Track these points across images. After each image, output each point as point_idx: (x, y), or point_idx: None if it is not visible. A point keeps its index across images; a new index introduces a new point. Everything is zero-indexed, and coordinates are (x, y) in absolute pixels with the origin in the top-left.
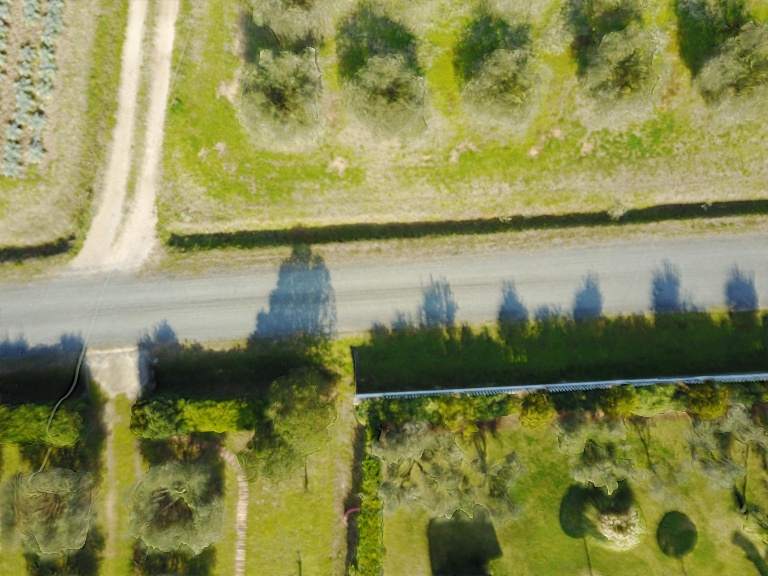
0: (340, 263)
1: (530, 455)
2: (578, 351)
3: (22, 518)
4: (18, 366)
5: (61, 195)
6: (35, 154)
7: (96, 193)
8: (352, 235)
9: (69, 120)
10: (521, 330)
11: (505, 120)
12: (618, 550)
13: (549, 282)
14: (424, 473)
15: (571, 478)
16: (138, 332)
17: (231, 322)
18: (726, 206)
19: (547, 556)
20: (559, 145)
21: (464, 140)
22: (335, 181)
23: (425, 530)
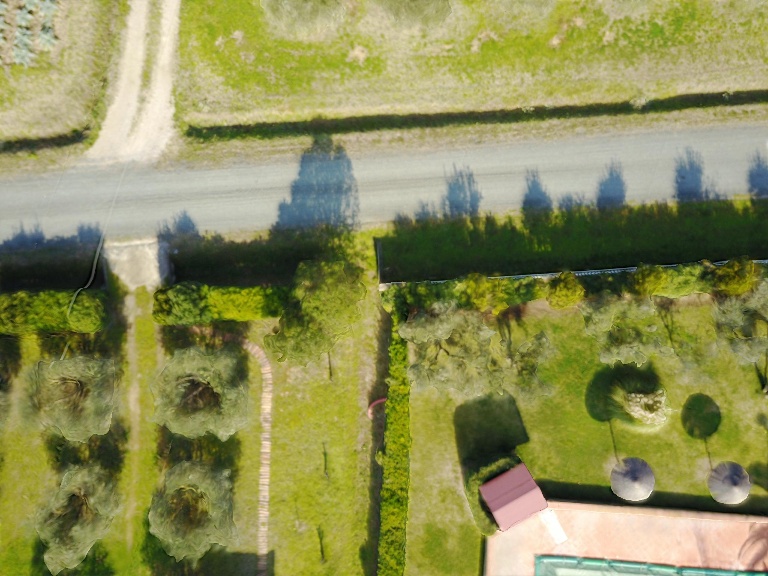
0: (362, 153)
1: (555, 342)
2: (601, 239)
3: (43, 406)
4: (33, 259)
5: (74, 85)
6: (47, 41)
7: (111, 82)
8: (374, 126)
9: (81, 6)
10: (545, 219)
11: (530, 2)
12: (643, 431)
13: (572, 170)
14: (451, 356)
15: (596, 363)
16: (157, 224)
17: (252, 213)
18: (747, 95)
19: (573, 439)
20: (582, 34)
21: (486, 29)
22: (356, 71)
23: (451, 418)
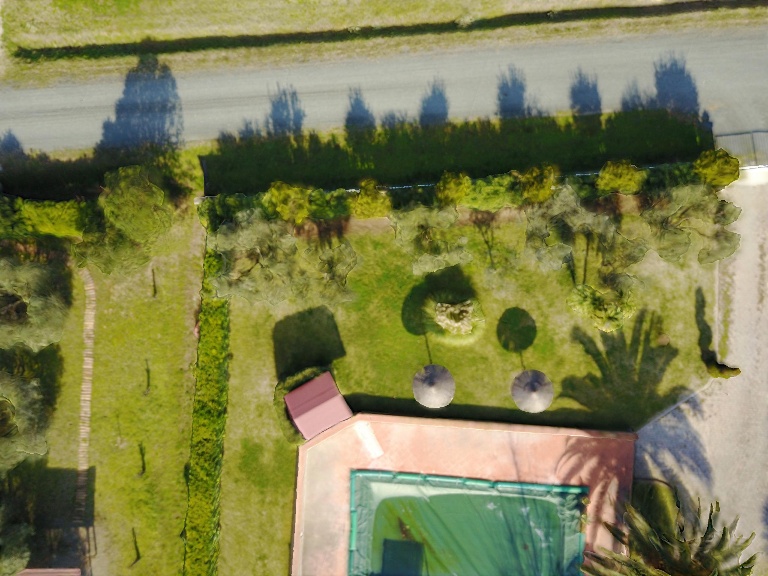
0: (187, 72)
1: (375, 258)
2: (424, 157)
3: None
4: None
5: None
6: None
7: None
8: (200, 46)
9: None
10: (368, 137)
11: None
12: (458, 345)
13: (395, 88)
14: (262, 267)
15: (414, 279)
16: None
17: (77, 131)
18: (572, 14)
19: (389, 354)
20: None
21: None
22: None
23: (270, 333)
